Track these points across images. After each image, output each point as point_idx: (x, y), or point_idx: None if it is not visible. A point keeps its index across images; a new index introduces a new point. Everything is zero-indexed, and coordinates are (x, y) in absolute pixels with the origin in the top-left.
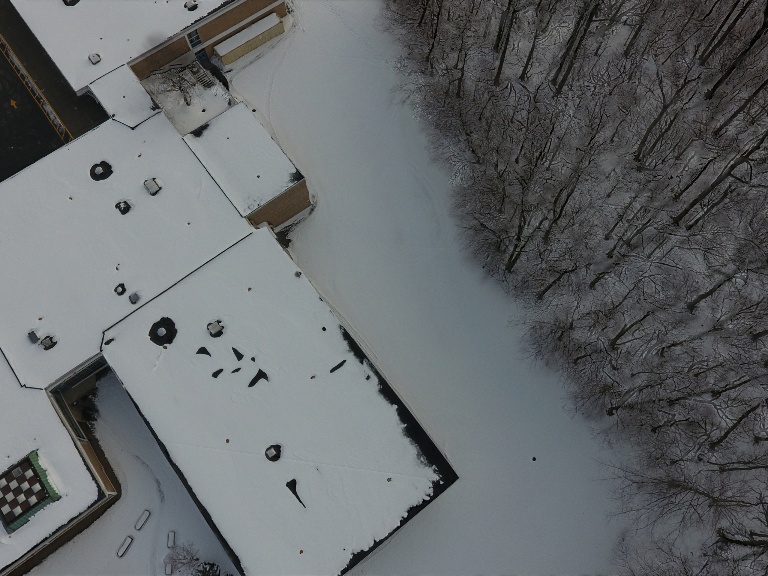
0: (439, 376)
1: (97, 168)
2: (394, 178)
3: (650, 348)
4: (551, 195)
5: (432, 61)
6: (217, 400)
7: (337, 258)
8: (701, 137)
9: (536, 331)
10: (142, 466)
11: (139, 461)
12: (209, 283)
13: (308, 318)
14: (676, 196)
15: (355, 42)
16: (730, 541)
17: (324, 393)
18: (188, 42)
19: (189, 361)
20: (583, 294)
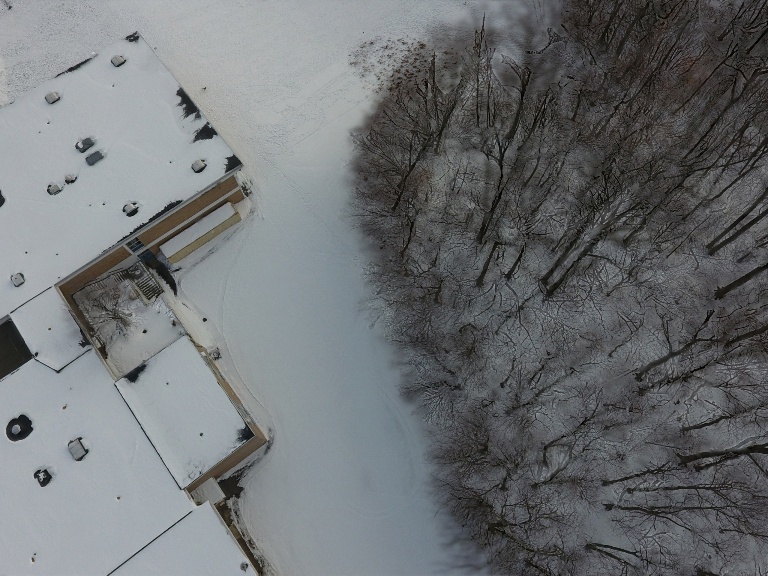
0: None
1: (14, 426)
2: (362, 405)
3: None
4: (540, 441)
5: (406, 266)
6: None
7: (295, 511)
8: None
9: None
10: None
11: None
12: None
13: None
14: (683, 427)
15: (320, 232)
16: None
17: None
18: (128, 249)
19: None
20: (577, 560)
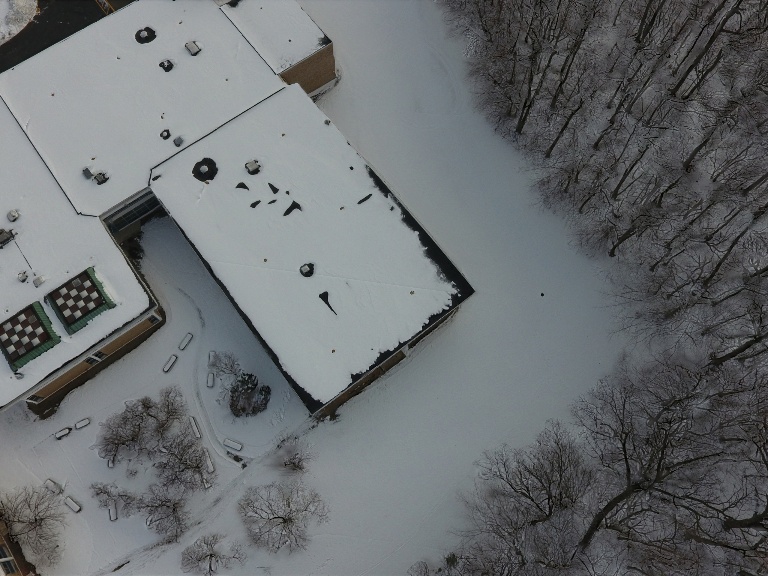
0: (455, 222)
1: (142, 32)
2: (412, 55)
3: (649, 195)
4: (558, 64)
5: None
6: (255, 226)
7: (360, 123)
8: (697, 19)
9: (544, 184)
10: (184, 297)
11: (181, 293)
12: (246, 129)
13: (337, 159)
14: (673, 72)
15: None
16: (721, 361)
17: (352, 221)
18: None
19: (229, 194)
20: (587, 153)
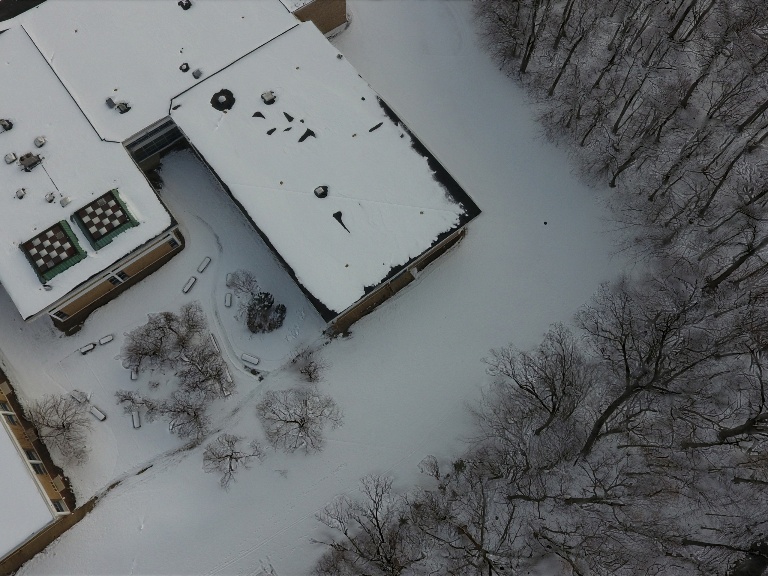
0: (462, 154)
1: None
2: (420, 1)
3: (648, 128)
4: (561, 7)
5: None
6: (272, 152)
7: (370, 64)
8: None
9: (547, 120)
10: (202, 224)
11: (200, 220)
12: (262, 63)
13: (349, 90)
14: (672, 17)
15: None
16: (717, 283)
17: (364, 147)
18: None
19: (246, 122)
20: None
